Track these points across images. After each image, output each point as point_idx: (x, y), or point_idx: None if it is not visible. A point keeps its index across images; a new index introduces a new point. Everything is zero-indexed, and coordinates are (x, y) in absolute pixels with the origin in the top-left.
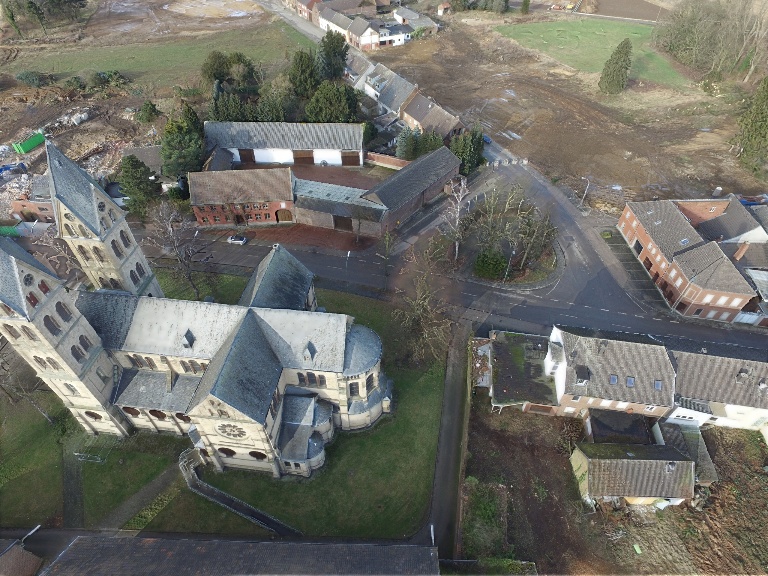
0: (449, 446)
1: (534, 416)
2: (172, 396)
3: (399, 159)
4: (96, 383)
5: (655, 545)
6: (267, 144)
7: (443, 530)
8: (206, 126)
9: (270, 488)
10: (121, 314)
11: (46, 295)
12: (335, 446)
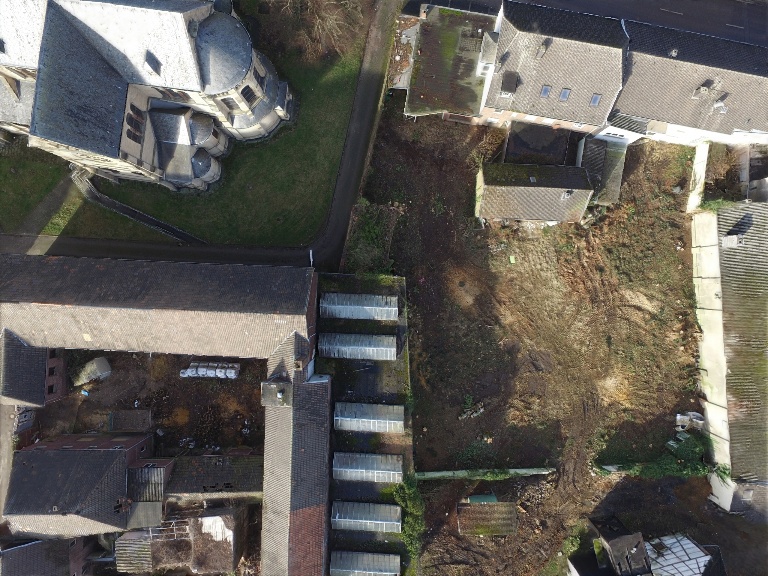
0: (353, 159)
1: (453, 125)
2: (24, 107)
3: None
4: None
5: (530, 257)
6: None
7: (337, 241)
8: None
9: (170, 200)
10: None
11: None
12: (231, 158)
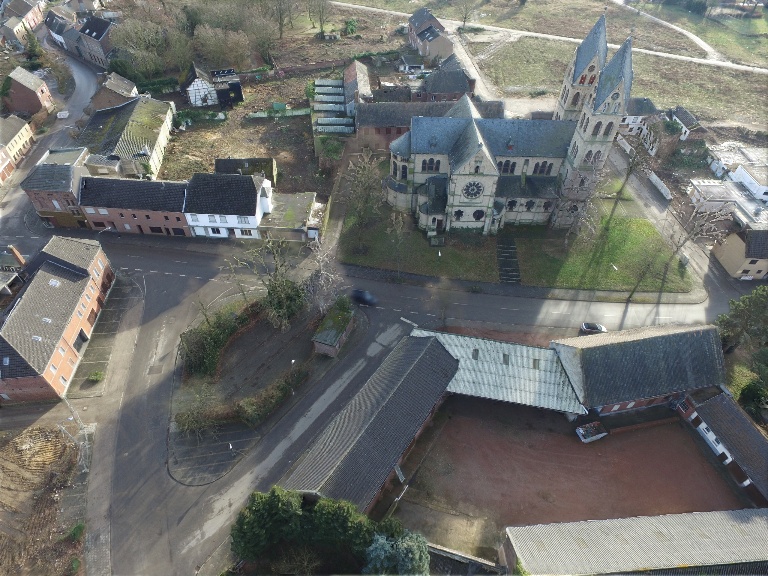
0: None
1: None
2: None
3: None
4: None
5: None
6: (723, 518)
7: None
8: None
9: None
10: None
11: None
12: None
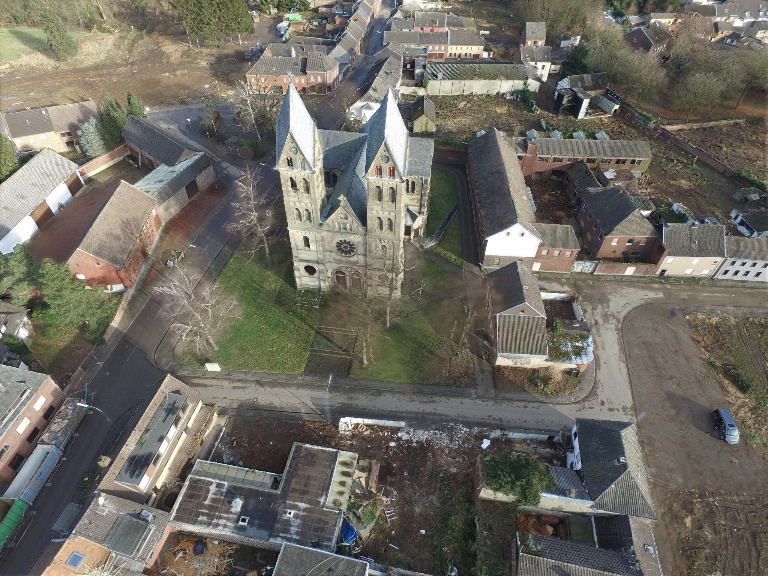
0: None
1: None
2: None
3: (105, 155)
4: None
5: None
6: (5, 226)
7: (449, 166)
8: None
9: (434, 214)
10: (362, 190)
11: None
12: None
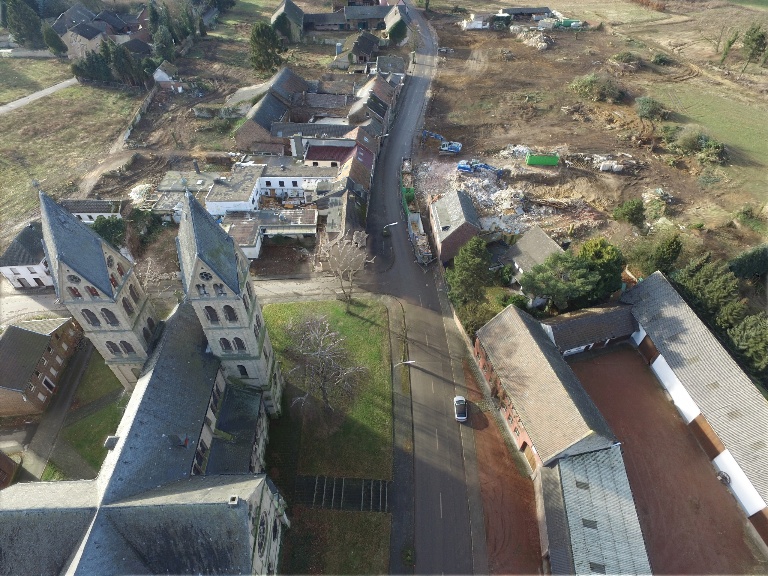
0: None
1: None
2: None
3: None
4: (128, 374)
5: None
6: (680, 367)
7: None
8: (653, 276)
9: None
10: None
11: (96, 297)
12: None
